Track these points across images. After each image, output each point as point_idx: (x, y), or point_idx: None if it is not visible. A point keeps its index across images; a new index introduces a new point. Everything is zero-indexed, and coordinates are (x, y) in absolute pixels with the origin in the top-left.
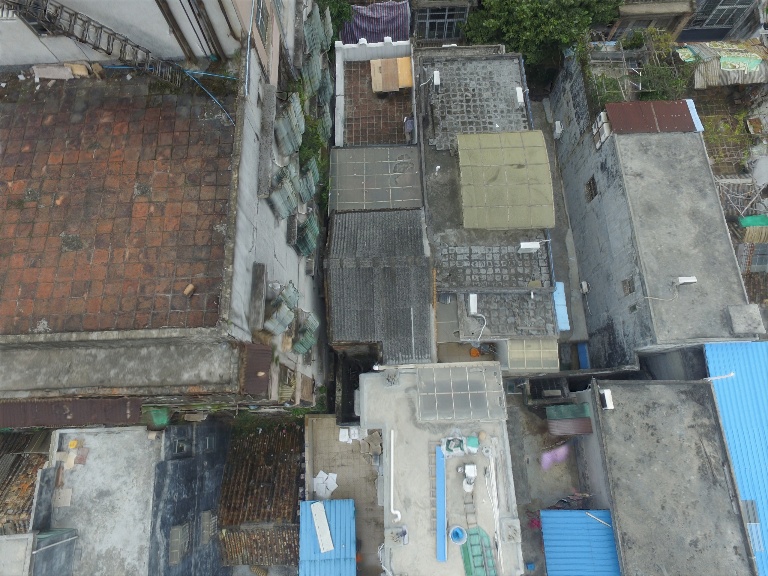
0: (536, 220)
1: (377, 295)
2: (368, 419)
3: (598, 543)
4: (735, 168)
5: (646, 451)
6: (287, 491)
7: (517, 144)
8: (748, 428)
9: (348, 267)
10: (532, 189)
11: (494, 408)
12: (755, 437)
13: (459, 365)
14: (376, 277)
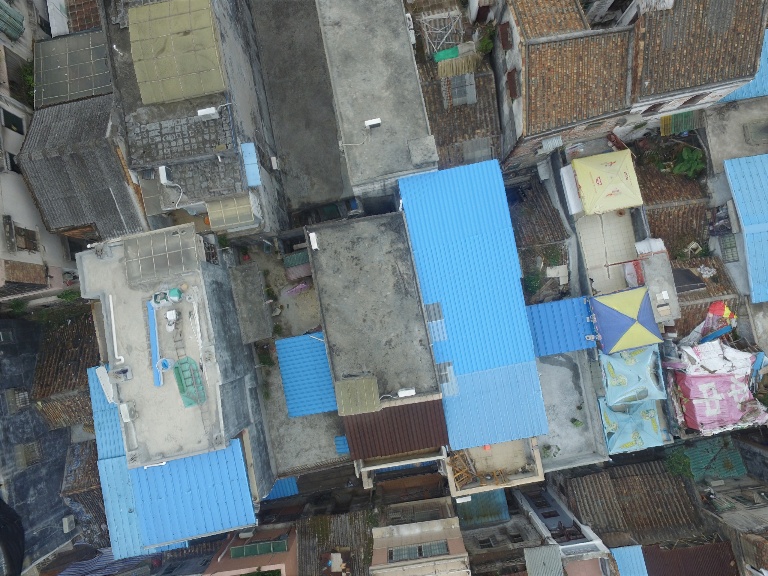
0: (207, 86)
1: (74, 181)
2: (90, 290)
3: (319, 357)
4: (457, 1)
5: (351, 279)
6: (90, 365)
7: (184, 10)
8: (435, 246)
9: (37, 159)
10: (198, 55)
11: (192, 263)
12: (441, 252)
13: (158, 231)
14: (67, 164)
